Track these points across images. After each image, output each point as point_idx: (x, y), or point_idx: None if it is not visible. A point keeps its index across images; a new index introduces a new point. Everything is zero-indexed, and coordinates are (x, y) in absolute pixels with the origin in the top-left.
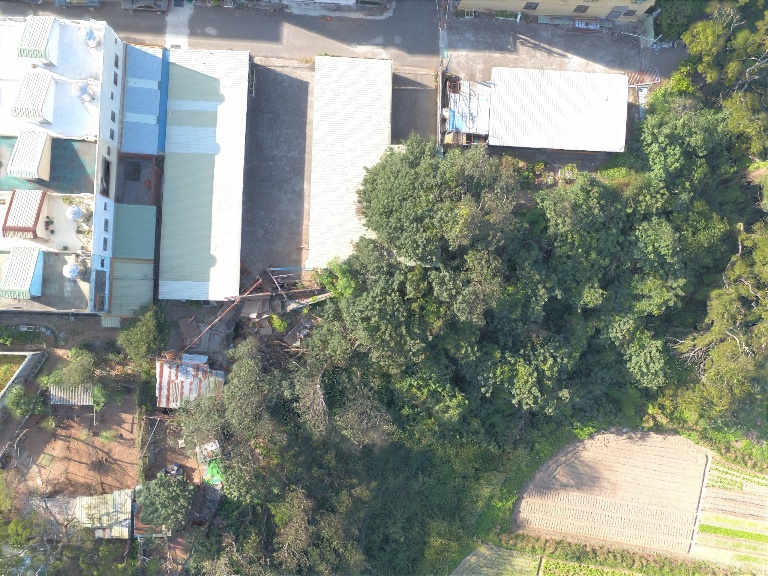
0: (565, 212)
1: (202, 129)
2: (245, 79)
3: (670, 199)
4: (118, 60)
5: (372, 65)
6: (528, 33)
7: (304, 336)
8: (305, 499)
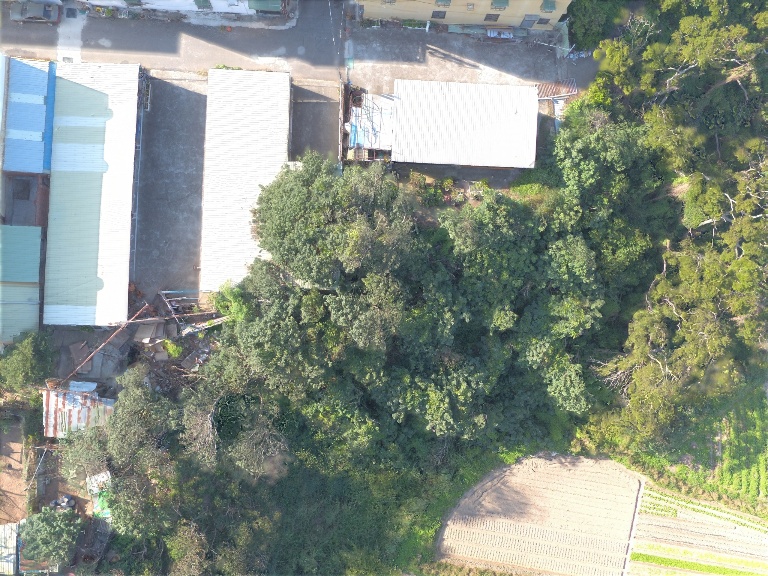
0: (465, 233)
1: (89, 146)
2: (135, 93)
3: (588, 216)
4: None
5: (269, 78)
6: (438, 43)
7: (203, 361)
8: (198, 533)
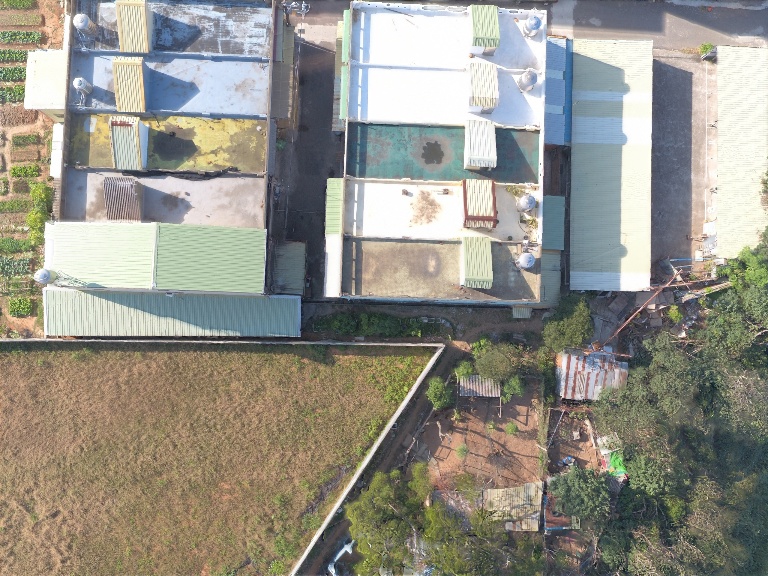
0: None
1: (608, 119)
2: (649, 69)
3: None
4: None
5: None
6: None
7: (688, 327)
8: (714, 491)
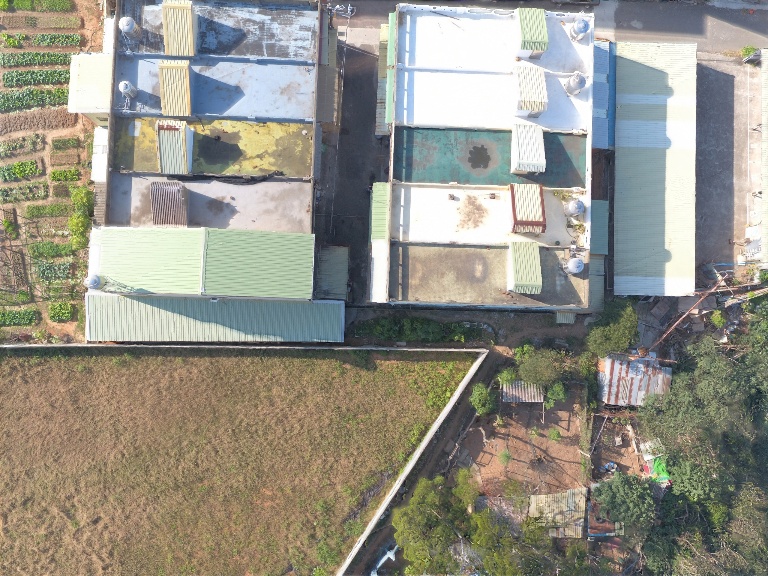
0: None
1: (652, 123)
2: (693, 72)
3: None
4: None
5: None
6: None
7: (730, 332)
8: (758, 497)
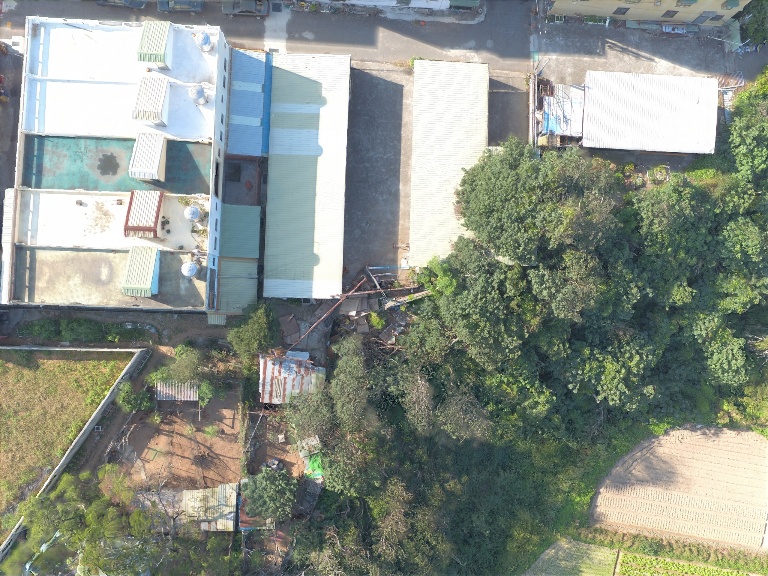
0: (663, 212)
1: (305, 131)
2: (346, 82)
3: (754, 200)
4: (226, 64)
5: (469, 69)
6: (616, 37)
7: (399, 333)
8: (405, 492)
